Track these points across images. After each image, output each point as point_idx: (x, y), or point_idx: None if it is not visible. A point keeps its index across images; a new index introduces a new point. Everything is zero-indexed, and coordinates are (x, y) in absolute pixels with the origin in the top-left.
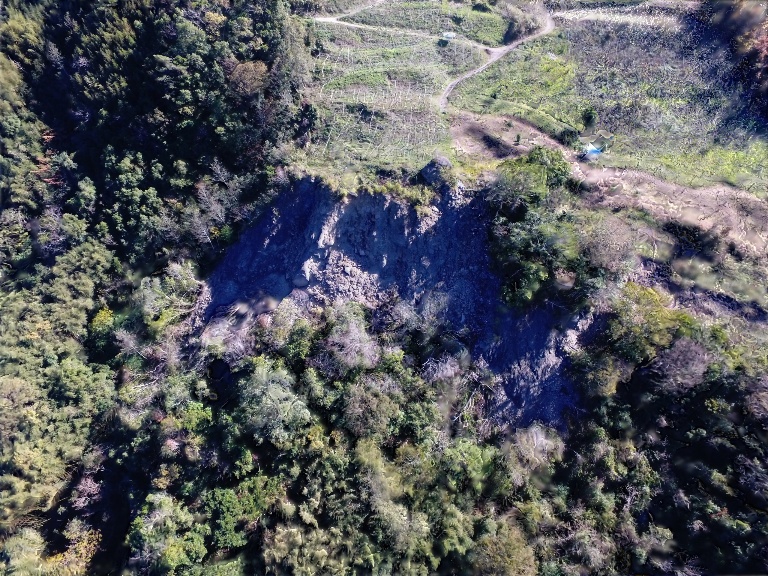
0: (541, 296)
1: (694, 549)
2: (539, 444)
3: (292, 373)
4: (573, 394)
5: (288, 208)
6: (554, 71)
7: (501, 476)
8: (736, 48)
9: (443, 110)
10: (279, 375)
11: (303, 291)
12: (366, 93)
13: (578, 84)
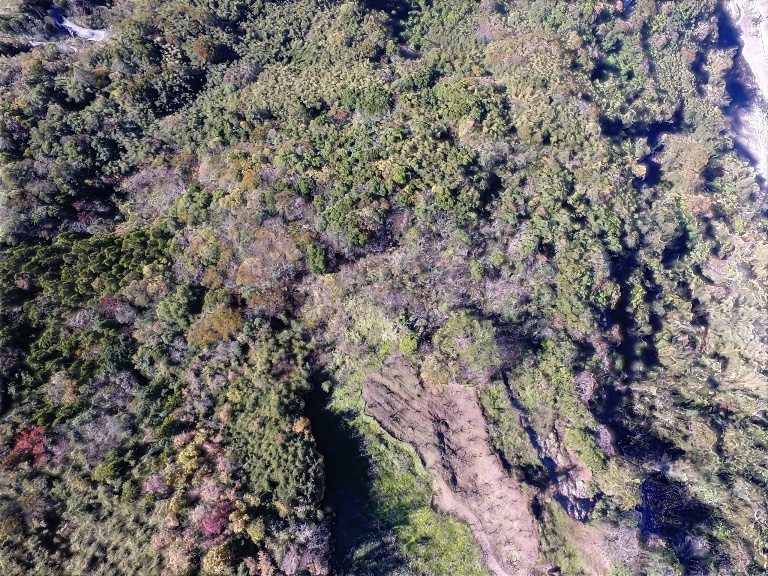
0: None
1: None
2: None
3: None
4: None
5: None
6: None
7: None
8: None
9: None
10: None
11: None
12: None
13: None
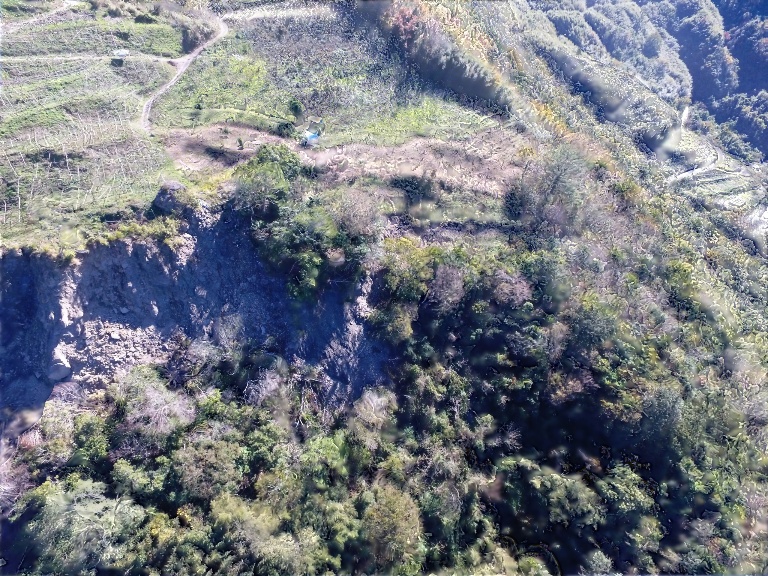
0: (323, 279)
1: (509, 418)
2: (376, 405)
3: (99, 477)
4: (383, 349)
5: None
6: (246, 71)
7: (358, 450)
8: (382, 26)
9: (150, 133)
10: (83, 488)
11: (68, 382)
12: (46, 135)
13: (273, 79)
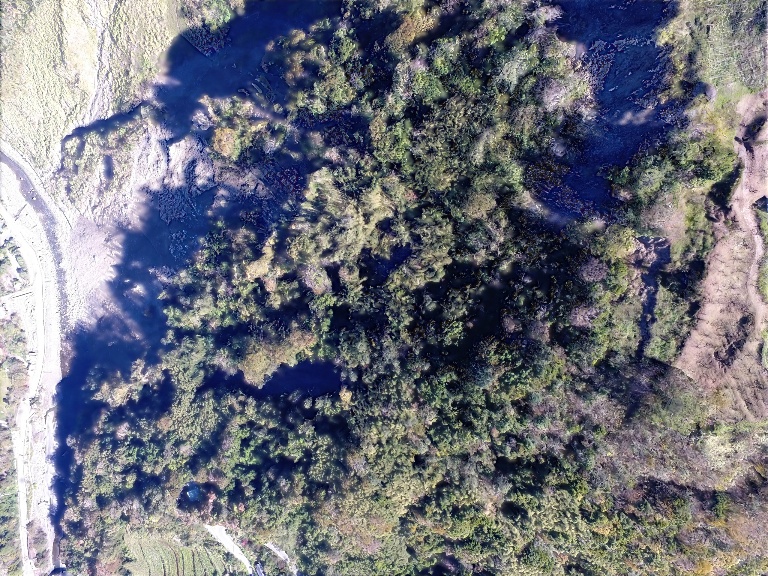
0: None
1: None
2: None
3: (521, 71)
4: None
5: (640, 6)
6: None
7: (509, 195)
8: None
9: None
10: (514, 65)
11: None
12: None
13: None
